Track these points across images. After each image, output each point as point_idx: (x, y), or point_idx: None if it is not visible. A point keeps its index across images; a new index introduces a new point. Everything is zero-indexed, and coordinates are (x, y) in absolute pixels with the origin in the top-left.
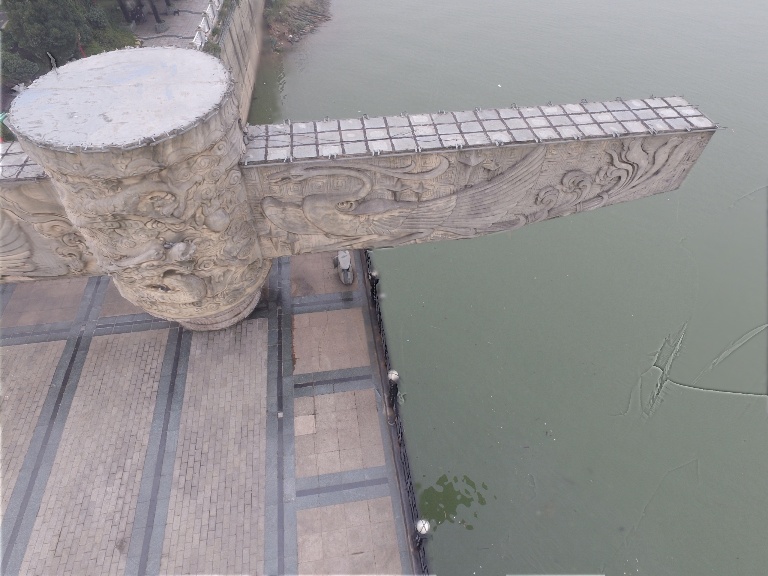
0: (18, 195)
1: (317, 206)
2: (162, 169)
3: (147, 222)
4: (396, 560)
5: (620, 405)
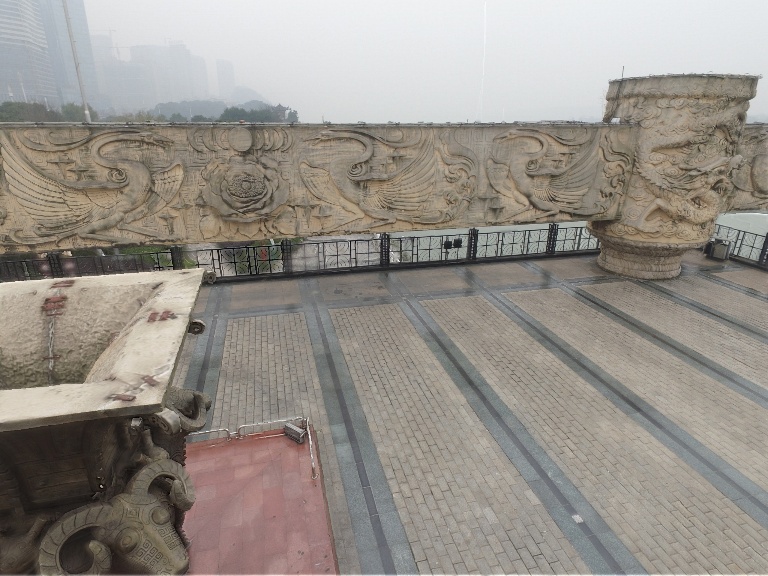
0: (615, 136)
1: (763, 162)
2: (748, 98)
3: (721, 139)
4: None
5: None
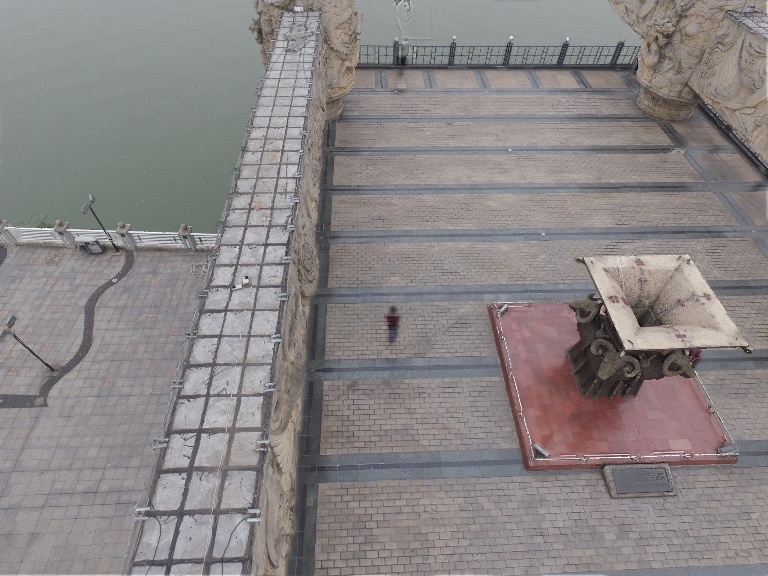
0: None
1: None
2: None
3: None
4: (455, 71)
5: (400, 33)
